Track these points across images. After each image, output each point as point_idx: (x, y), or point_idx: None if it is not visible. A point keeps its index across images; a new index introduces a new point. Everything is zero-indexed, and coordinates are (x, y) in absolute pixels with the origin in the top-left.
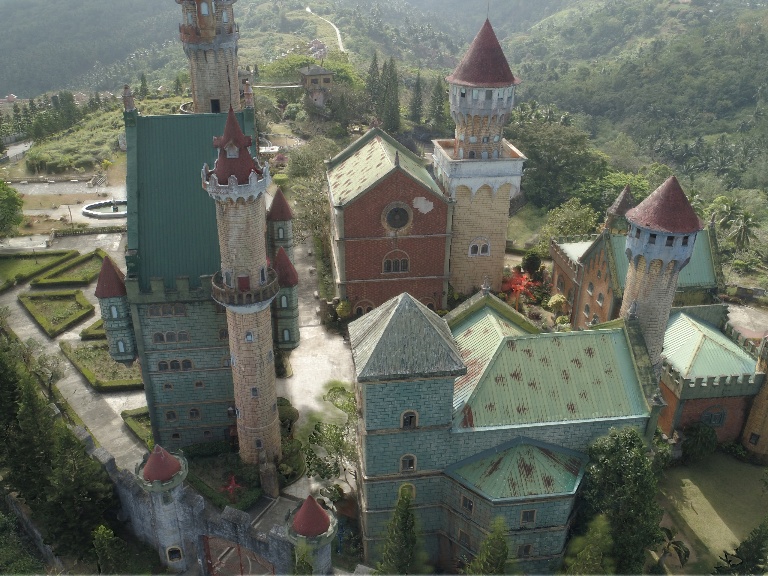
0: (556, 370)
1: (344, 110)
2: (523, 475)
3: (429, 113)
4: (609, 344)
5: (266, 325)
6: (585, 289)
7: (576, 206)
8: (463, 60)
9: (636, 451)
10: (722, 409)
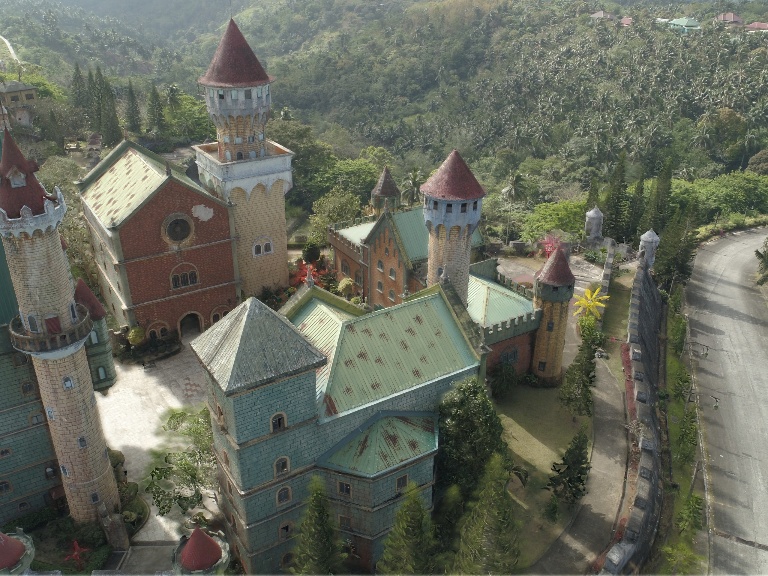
0: (395, 342)
1: (57, 127)
2: (391, 446)
3: (149, 122)
4: (432, 309)
5: (84, 366)
6: (375, 268)
7: (340, 193)
8: (214, 62)
9: (481, 396)
10: (515, 347)
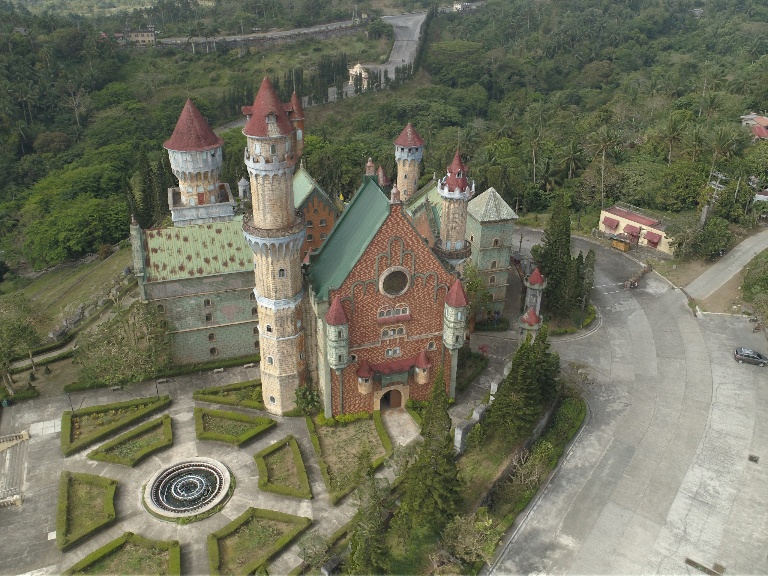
0: None
1: None
2: None
3: None
4: None
5: None
6: None
7: None
8: (196, 132)
9: None
10: None
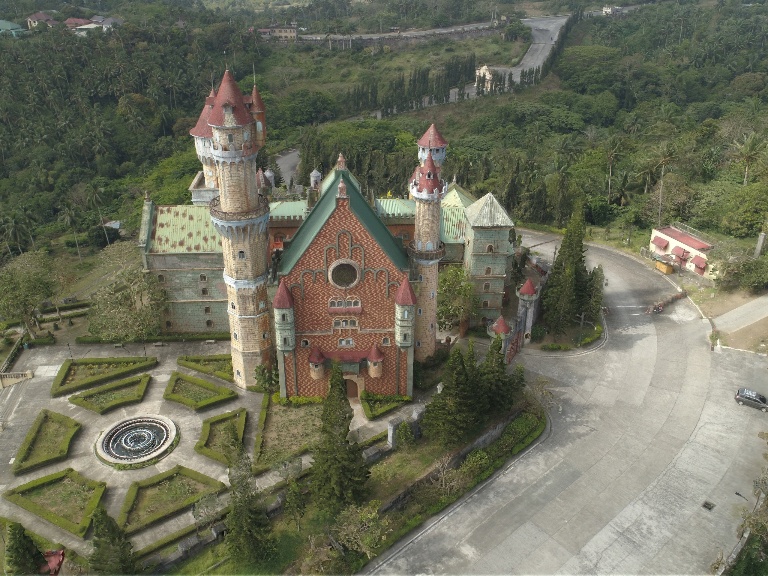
0: None
1: None
2: None
3: None
4: None
5: None
6: None
7: None
8: None
9: None
10: None
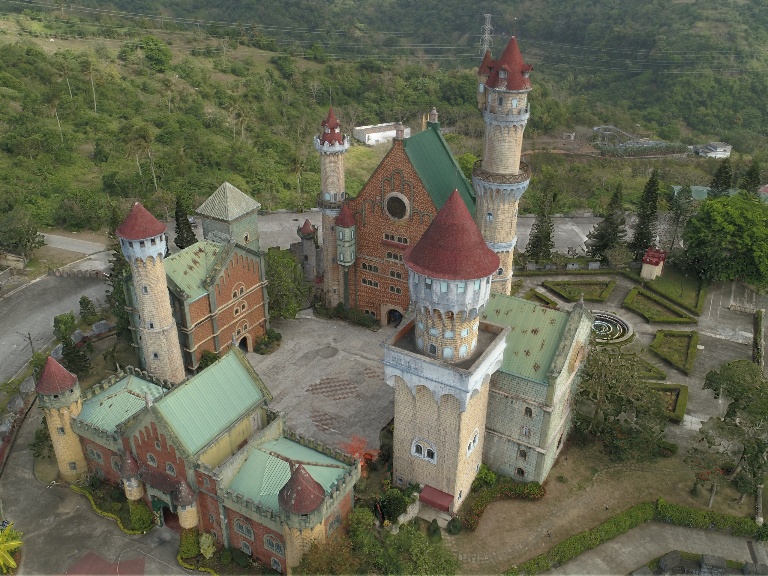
0: None
1: None
2: None
3: None
4: None
5: None
6: None
7: None
8: None
9: None
10: None
